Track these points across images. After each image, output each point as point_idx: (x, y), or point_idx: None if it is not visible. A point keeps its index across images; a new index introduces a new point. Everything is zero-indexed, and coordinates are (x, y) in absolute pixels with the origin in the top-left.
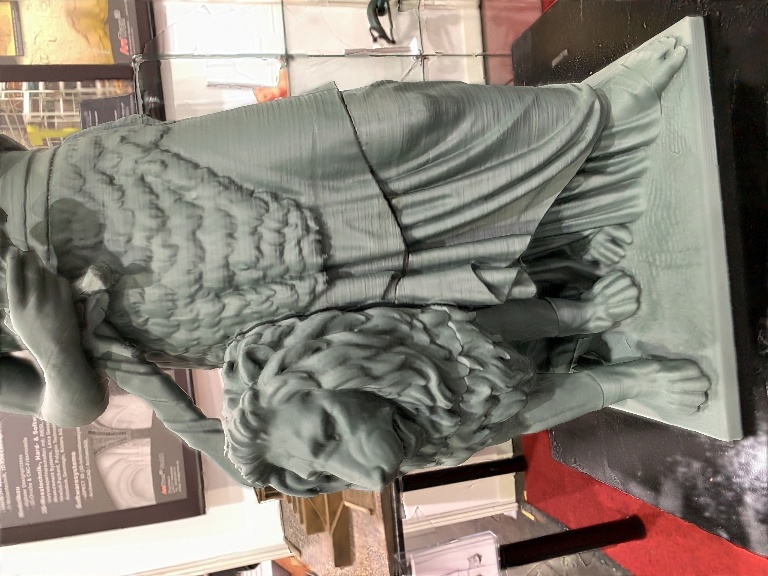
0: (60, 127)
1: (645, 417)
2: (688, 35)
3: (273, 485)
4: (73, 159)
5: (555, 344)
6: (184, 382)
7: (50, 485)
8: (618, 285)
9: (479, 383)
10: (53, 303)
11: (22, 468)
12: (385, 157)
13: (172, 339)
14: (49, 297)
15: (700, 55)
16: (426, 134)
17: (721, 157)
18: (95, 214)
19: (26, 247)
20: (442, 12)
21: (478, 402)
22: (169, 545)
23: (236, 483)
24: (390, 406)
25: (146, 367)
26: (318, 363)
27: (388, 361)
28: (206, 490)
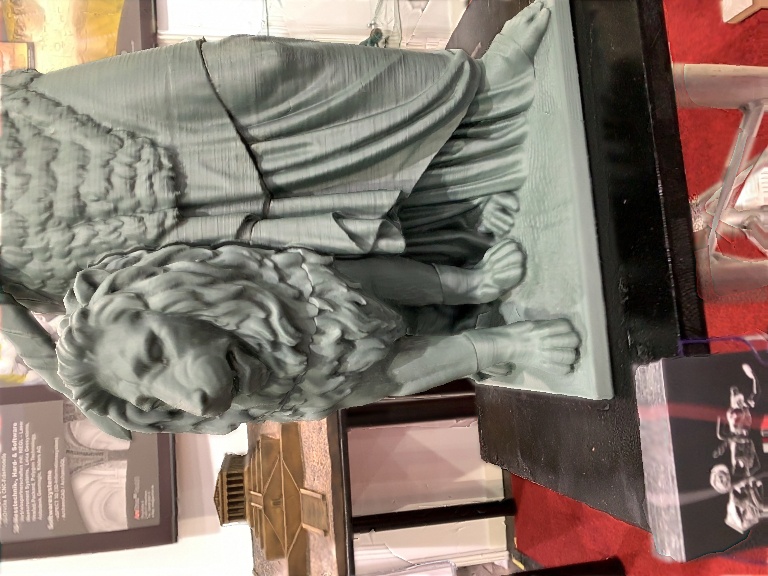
0: None
1: (546, 396)
2: None
3: (112, 417)
4: None
5: (456, 321)
6: None
7: (24, 503)
8: (504, 251)
9: (330, 325)
10: None
11: None
12: (241, 101)
13: (27, 269)
14: None
15: (563, 16)
16: (282, 81)
17: (586, 112)
18: None
19: None
20: None
21: (328, 344)
22: (139, 574)
23: (213, 513)
24: (229, 338)
25: None
26: (149, 285)
27: (223, 289)
28: (180, 517)
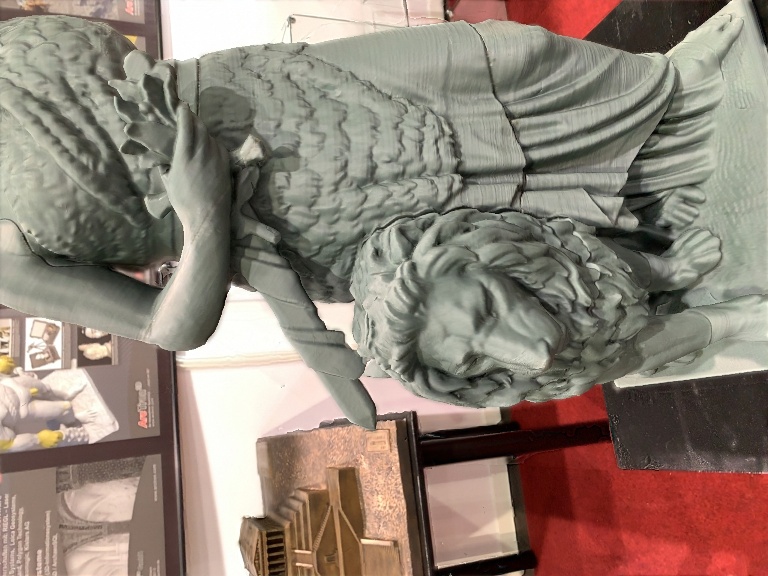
0: None
1: (732, 381)
2: (742, 9)
3: (416, 384)
4: (220, 59)
5: None
6: (171, 467)
7: None
8: (699, 237)
9: (609, 289)
10: (215, 161)
11: None
12: (508, 77)
13: (309, 233)
14: (212, 155)
15: (754, 25)
16: (542, 61)
17: None
18: (246, 100)
19: None
20: None
21: (610, 308)
22: None
23: None
24: (535, 297)
25: (282, 260)
26: (473, 238)
27: (535, 245)
28: None
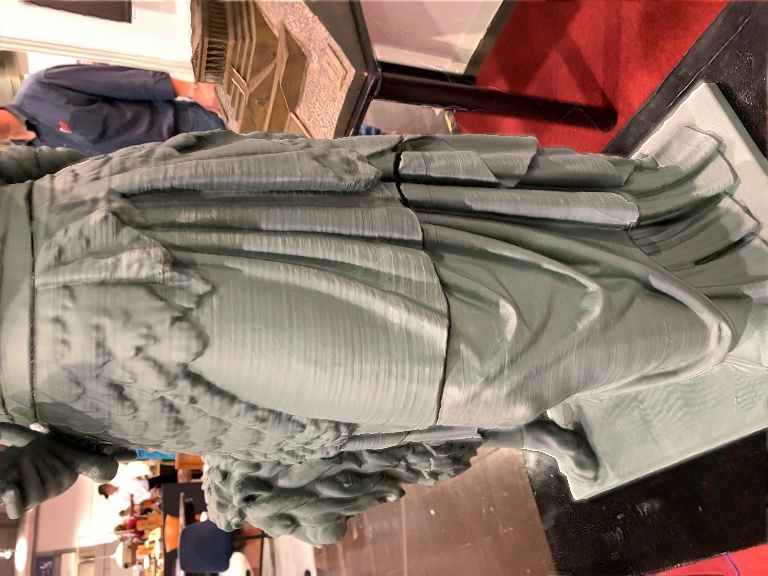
0: None
1: None
2: None
3: None
4: (65, 361)
5: None
6: None
7: None
8: None
9: None
10: (55, 495)
11: None
12: None
13: None
14: (51, 495)
15: None
16: None
17: (759, 434)
18: (98, 422)
19: None
20: None
21: None
22: None
23: None
24: None
25: None
26: (304, 515)
27: (363, 506)
28: None
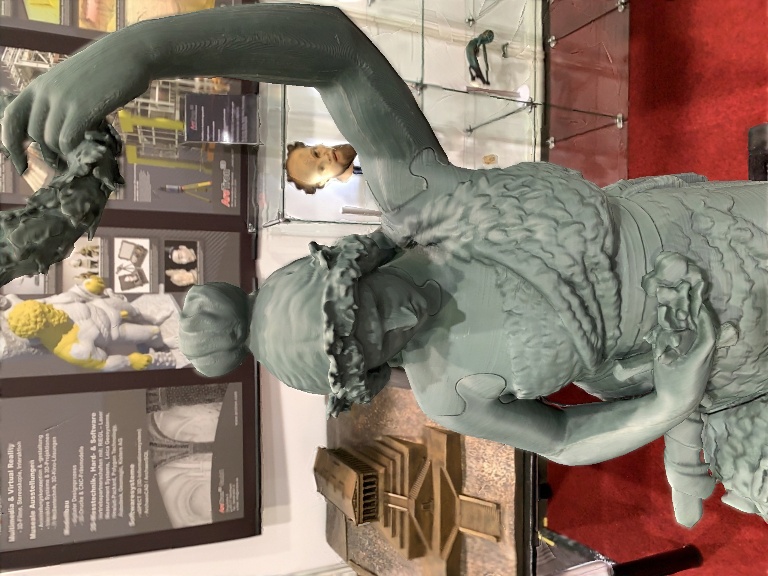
0: (153, 116)
1: None
2: None
3: None
4: (672, 217)
5: None
6: (252, 396)
7: (103, 500)
8: None
9: None
10: None
11: (75, 480)
12: None
13: (721, 391)
14: None
15: None
16: None
17: None
18: (706, 273)
19: (644, 297)
20: (513, 60)
21: None
22: (216, 567)
23: (284, 502)
24: None
25: (700, 415)
26: None
27: None
28: (262, 509)
